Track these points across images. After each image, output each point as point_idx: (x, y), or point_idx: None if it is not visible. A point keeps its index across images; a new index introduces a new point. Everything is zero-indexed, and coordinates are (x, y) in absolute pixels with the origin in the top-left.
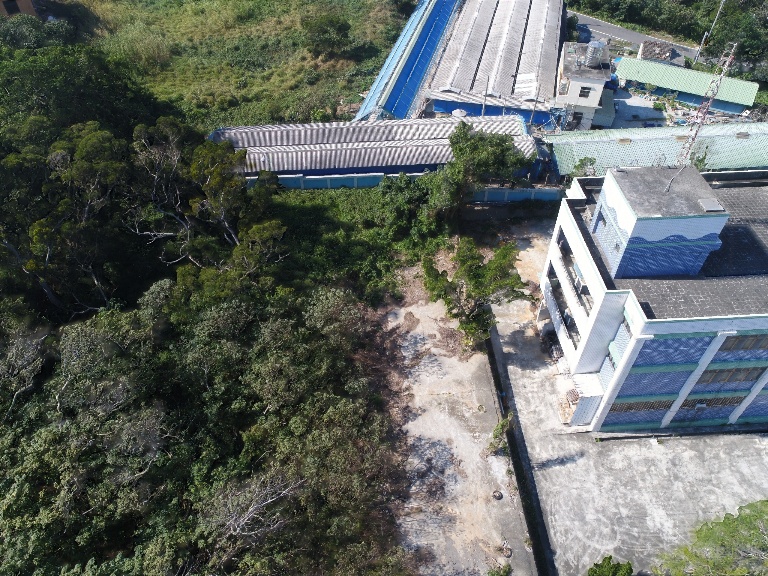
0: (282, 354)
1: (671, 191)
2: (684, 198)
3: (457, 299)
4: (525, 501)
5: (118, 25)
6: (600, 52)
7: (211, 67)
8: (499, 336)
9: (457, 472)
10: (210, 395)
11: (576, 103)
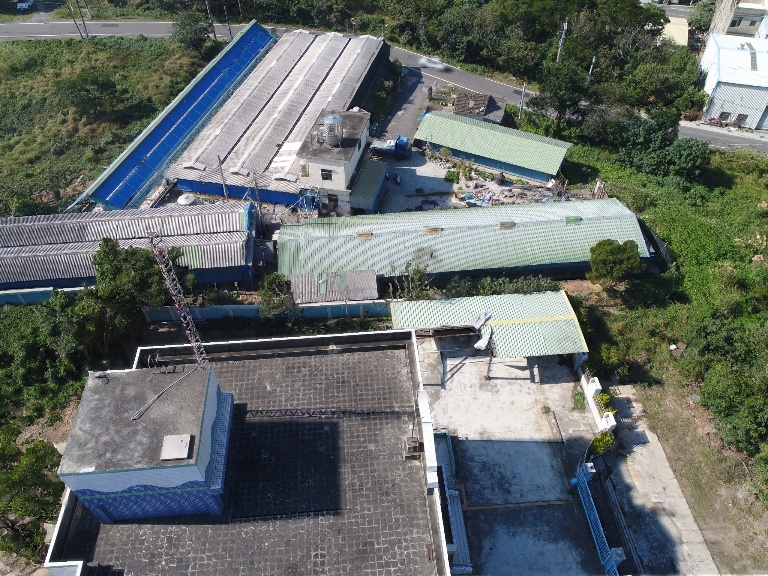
0: None
1: (143, 418)
2: (151, 432)
3: None
4: None
5: None
6: (338, 129)
7: None
8: None
9: None
10: None
11: (322, 186)
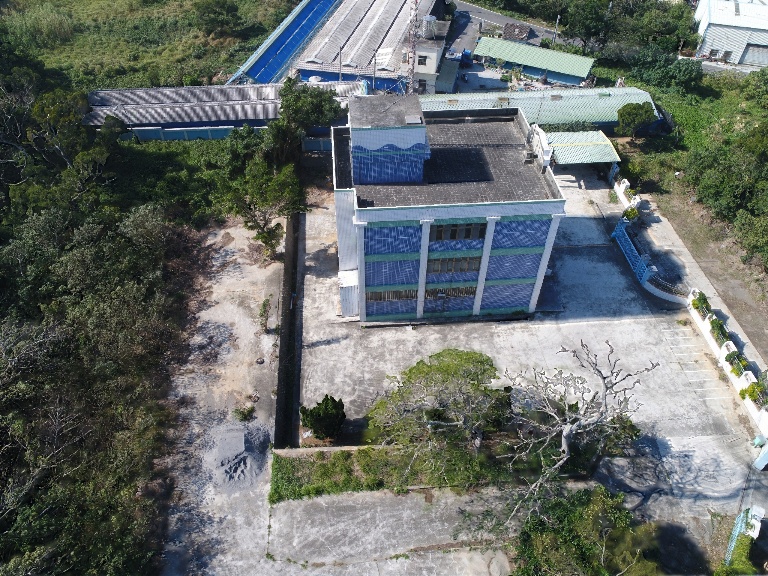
0: (88, 250)
1: (388, 111)
2: (396, 115)
3: (250, 213)
4: (287, 368)
5: (27, 6)
6: (433, 25)
7: (108, 43)
8: (305, 253)
9: (232, 345)
10: (22, 279)
11: (417, 70)
